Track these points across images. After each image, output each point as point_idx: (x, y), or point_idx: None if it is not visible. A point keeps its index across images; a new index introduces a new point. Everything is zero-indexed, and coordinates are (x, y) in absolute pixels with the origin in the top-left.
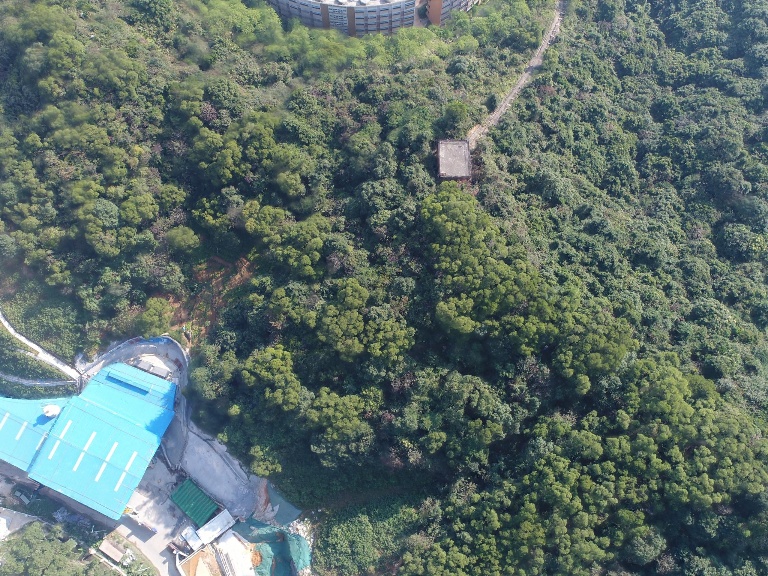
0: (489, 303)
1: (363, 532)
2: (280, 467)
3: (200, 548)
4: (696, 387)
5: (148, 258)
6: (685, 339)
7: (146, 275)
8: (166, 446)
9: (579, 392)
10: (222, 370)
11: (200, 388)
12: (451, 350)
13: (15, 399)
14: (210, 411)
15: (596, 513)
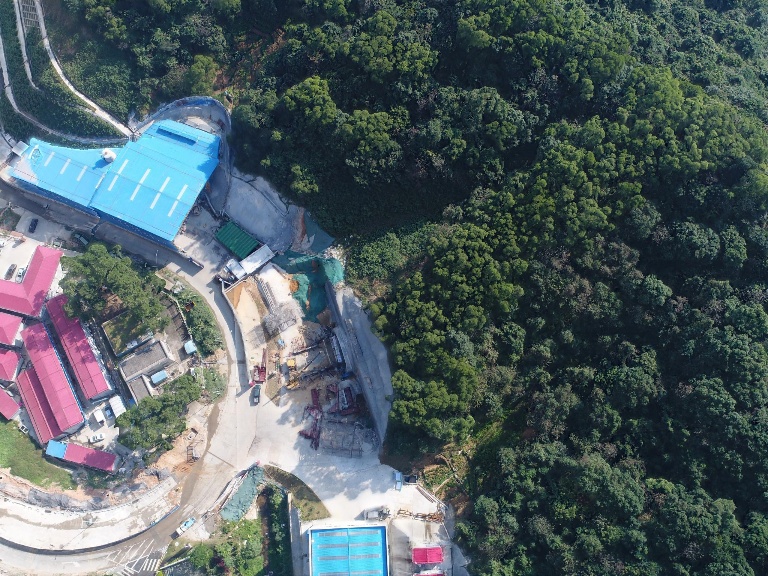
0: (504, 17)
1: (391, 245)
2: (317, 187)
3: (243, 278)
4: (686, 89)
5: (196, 18)
6: (677, 61)
7: (194, 33)
8: (210, 197)
9: (584, 97)
10: (265, 100)
11: (245, 118)
12: (470, 71)
13: (75, 149)
14: (253, 145)
15: (599, 186)
